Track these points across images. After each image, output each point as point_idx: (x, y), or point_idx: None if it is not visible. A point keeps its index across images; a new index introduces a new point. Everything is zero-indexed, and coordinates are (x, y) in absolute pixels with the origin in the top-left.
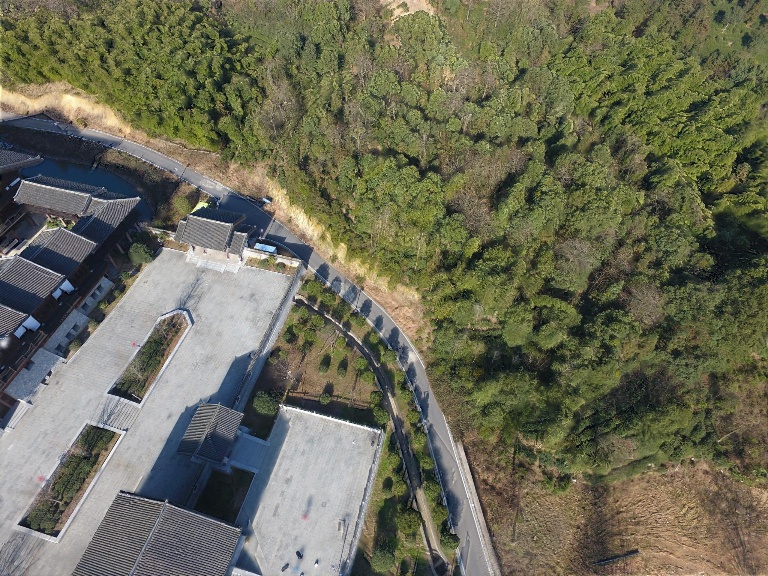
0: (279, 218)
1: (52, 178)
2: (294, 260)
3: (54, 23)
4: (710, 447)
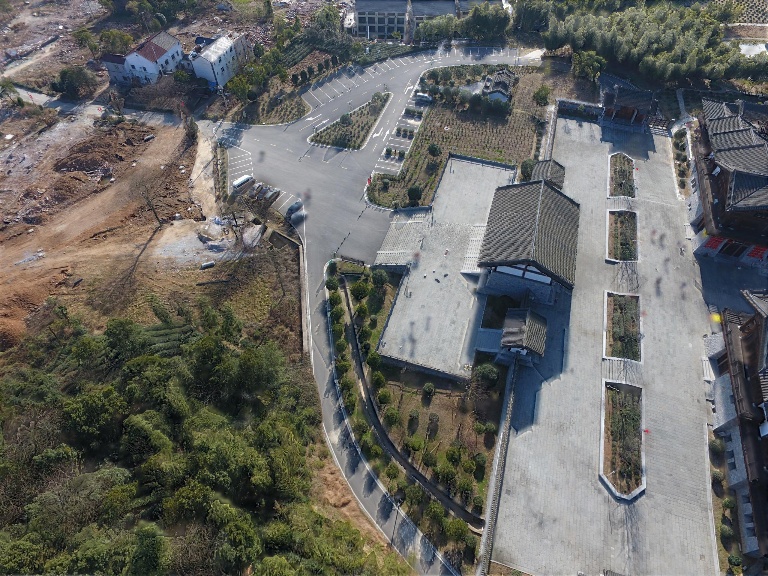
0: None
1: None
2: None
3: None
4: (79, 341)
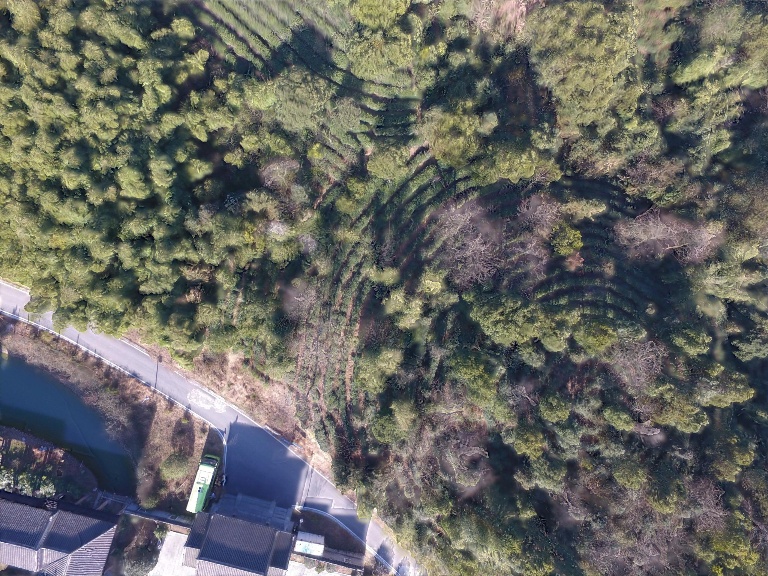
0: (319, 465)
1: None
2: None
3: None
4: None
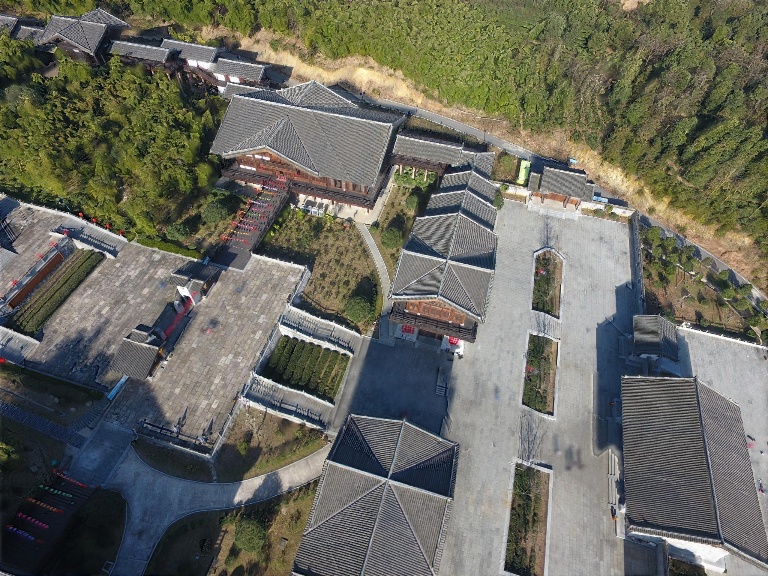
0: None
1: (412, 135)
2: (630, 209)
3: (356, 4)
4: None
